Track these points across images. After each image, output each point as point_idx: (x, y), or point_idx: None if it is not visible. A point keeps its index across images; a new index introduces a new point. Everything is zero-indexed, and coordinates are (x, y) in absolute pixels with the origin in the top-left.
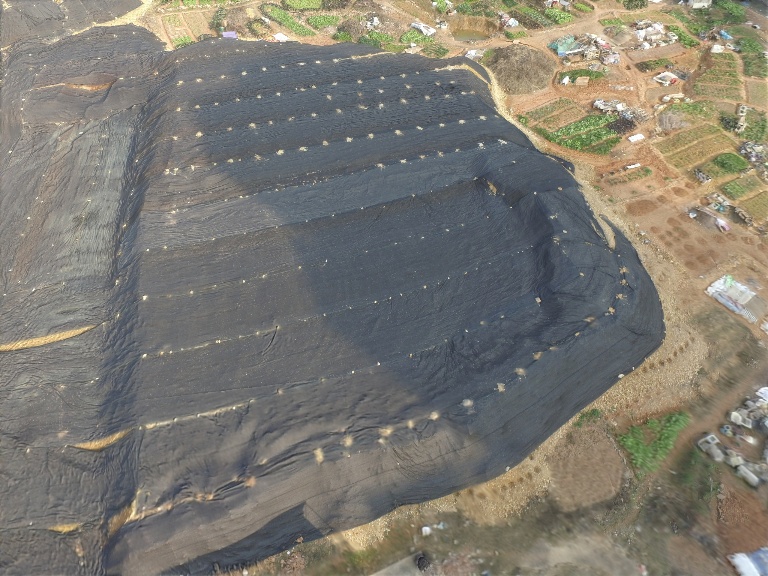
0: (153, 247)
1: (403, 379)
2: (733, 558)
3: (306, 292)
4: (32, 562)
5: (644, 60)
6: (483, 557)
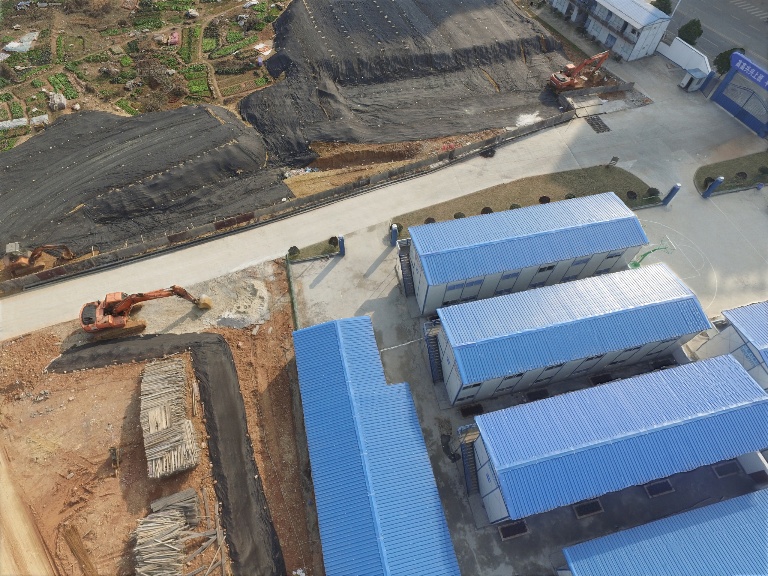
0: (450, 47)
1: None
2: None
3: (461, 14)
4: (558, 63)
5: None
6: (525, 0)
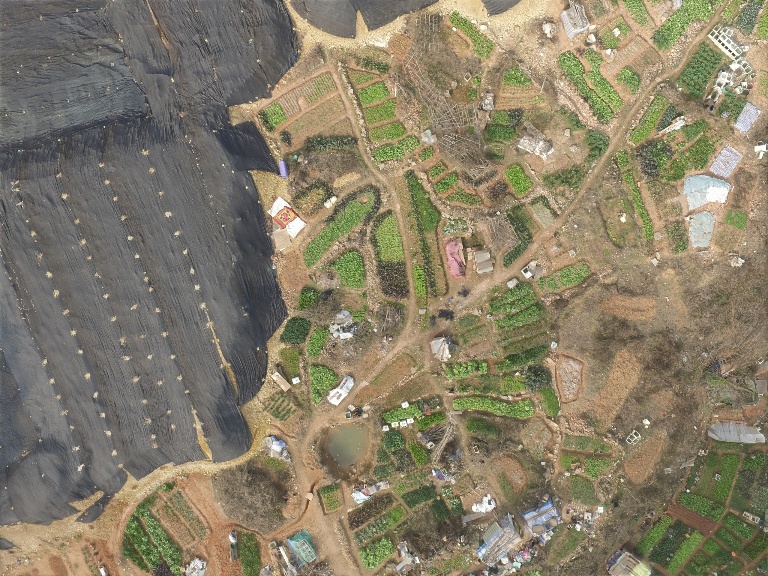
0: None
1: None
2: None
3: None
4: None
5: None
6: None
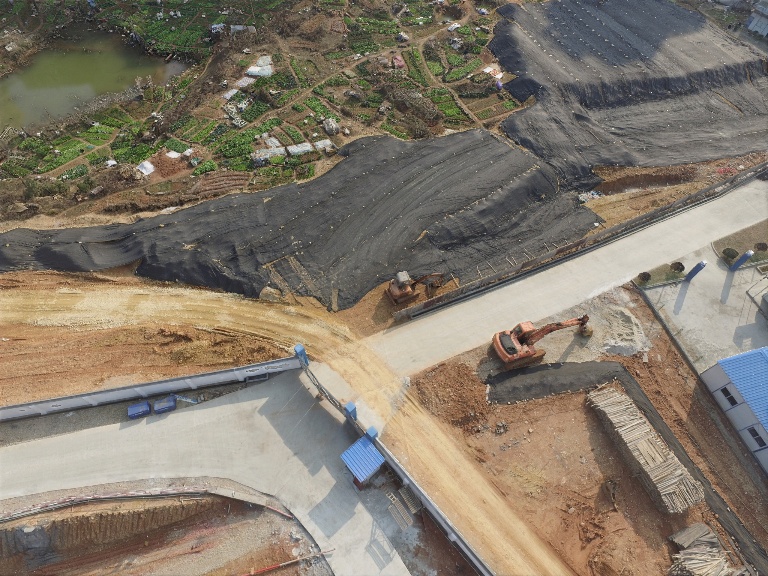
0: (683, 71)
1: None
2: None
3: None
4: None
5: None
6: None
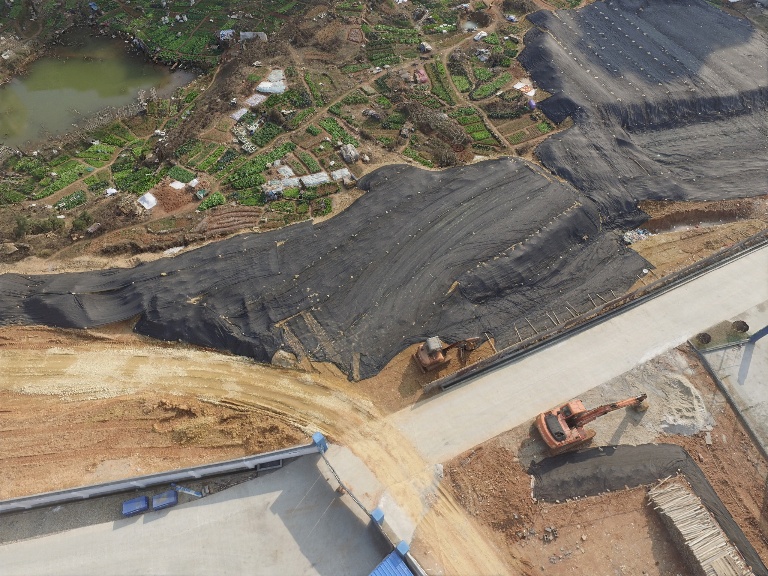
0: (735, 89)
1: (740, 31)
2: None
3: (724, 50)
4: None
5: None
6: None
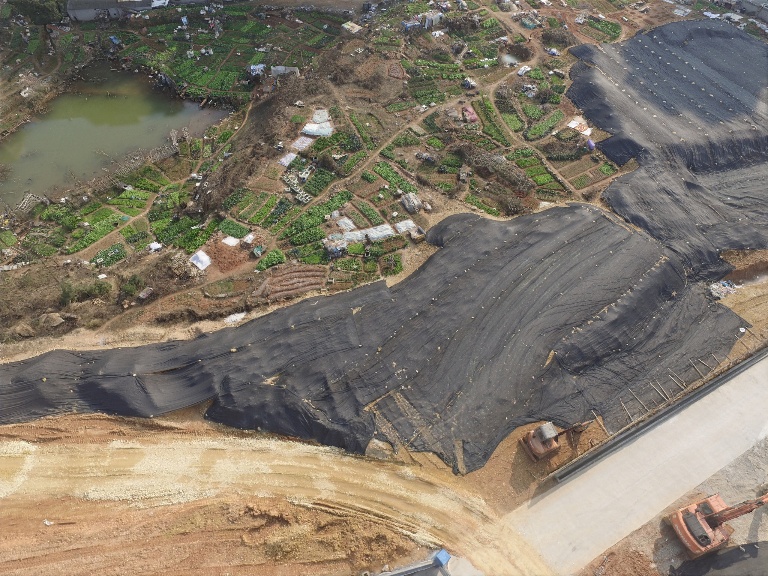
0: None
1: None
2: (767, 32)
3: None
4: None
5: (529, 6)
6: None
